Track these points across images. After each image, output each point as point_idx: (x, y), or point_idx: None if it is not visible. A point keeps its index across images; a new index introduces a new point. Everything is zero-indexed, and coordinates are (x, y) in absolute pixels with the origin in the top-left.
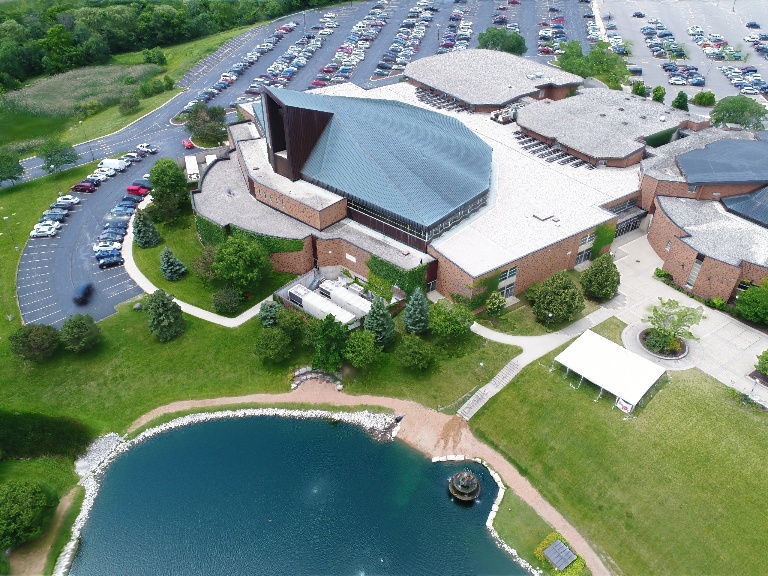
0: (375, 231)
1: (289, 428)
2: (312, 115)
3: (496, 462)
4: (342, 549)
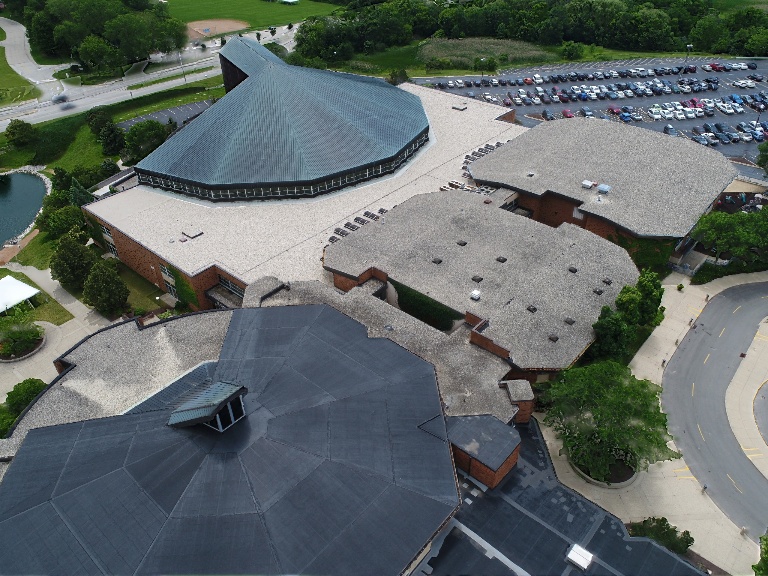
0: None
1: None
2: (236, 70)
3: None
4: None
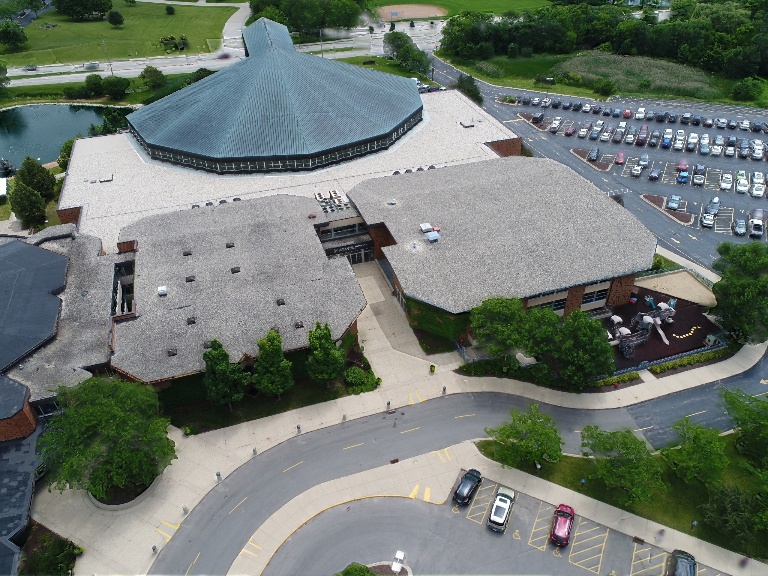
0: None
1: None
2: None
3: None
4: None
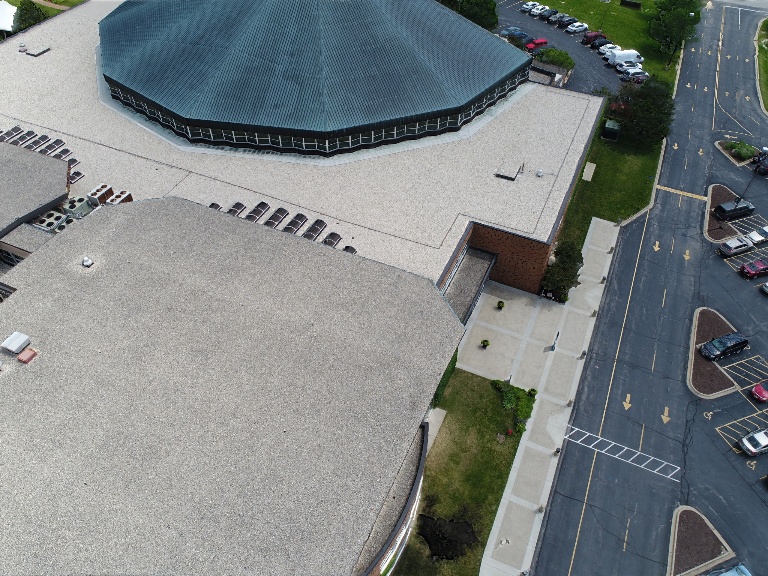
0: None
1: None
2: None
3: None
4: None
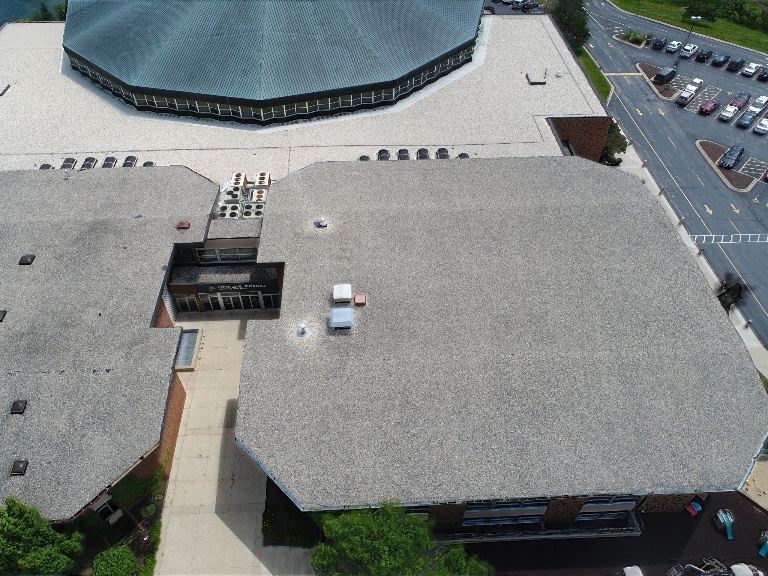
0: None
1: None
2: None
3: None
4: (7, 17)
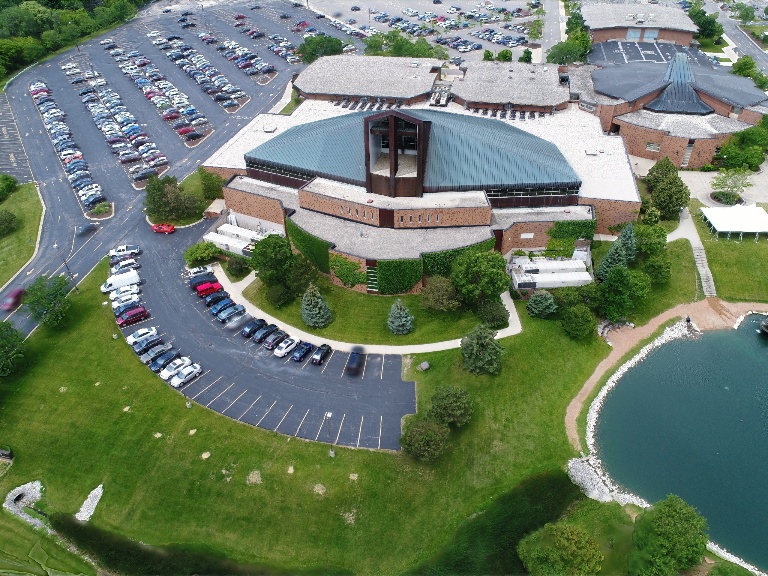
0: (520, 208)
1: (647, 370)
2: (427, 127)
3: (758, 307)
4: None
